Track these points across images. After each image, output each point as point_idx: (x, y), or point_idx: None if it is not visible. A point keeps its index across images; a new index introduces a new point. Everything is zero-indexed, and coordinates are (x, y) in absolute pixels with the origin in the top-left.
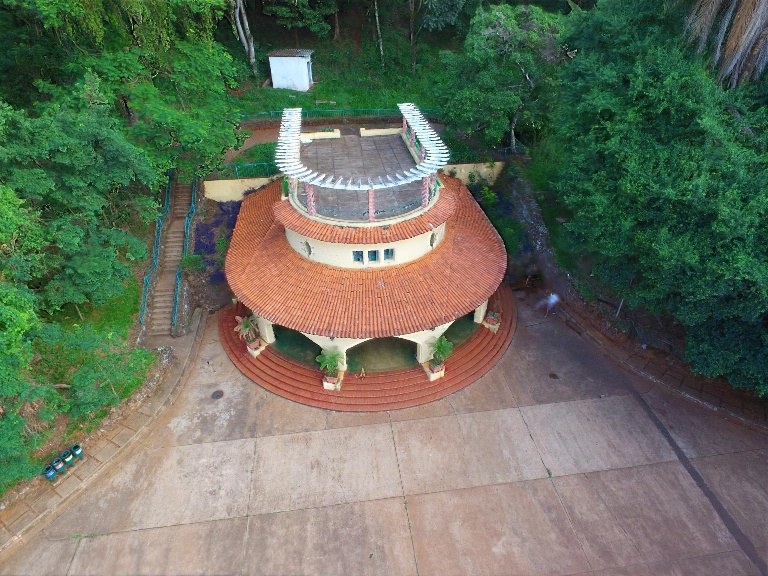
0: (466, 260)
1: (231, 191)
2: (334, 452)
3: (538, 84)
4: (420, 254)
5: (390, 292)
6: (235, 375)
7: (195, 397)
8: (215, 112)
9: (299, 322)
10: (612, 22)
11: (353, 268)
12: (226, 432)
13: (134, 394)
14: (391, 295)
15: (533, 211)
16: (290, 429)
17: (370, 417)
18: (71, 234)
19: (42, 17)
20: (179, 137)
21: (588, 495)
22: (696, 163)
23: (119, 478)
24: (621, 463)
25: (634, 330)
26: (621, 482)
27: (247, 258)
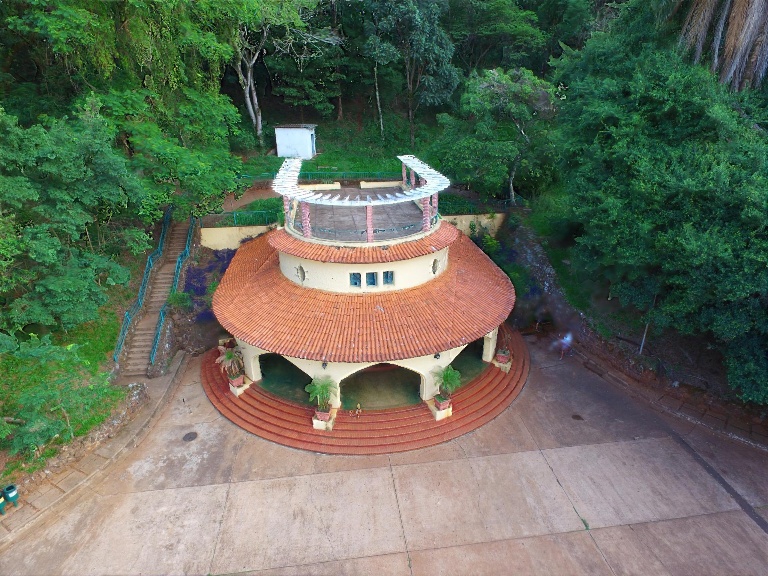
0: (471, 290)
1: (228, 239)
2: (322, 499)
3: (533, 143)
4: (422, 281)
5: (390, 316)
6: (213, 416)
7: (164, 439)
8: (217, 157)
9: (288, 346)
10: (605, 45)
11: (350, 293)
12: (195, 477)
13: (93, 432)
14: (391, 319)
15: (538, 254)
16: (271, 473)
17: (366, 460)
18: (47, 245)
19: (52, 41)
20: (177, 168)
21: (637, 551)
22: (712, 156)
23: (56, 529)
24: (672, 513)
25: (662, 367)
26: (676, 535)
27: (237, 290)
